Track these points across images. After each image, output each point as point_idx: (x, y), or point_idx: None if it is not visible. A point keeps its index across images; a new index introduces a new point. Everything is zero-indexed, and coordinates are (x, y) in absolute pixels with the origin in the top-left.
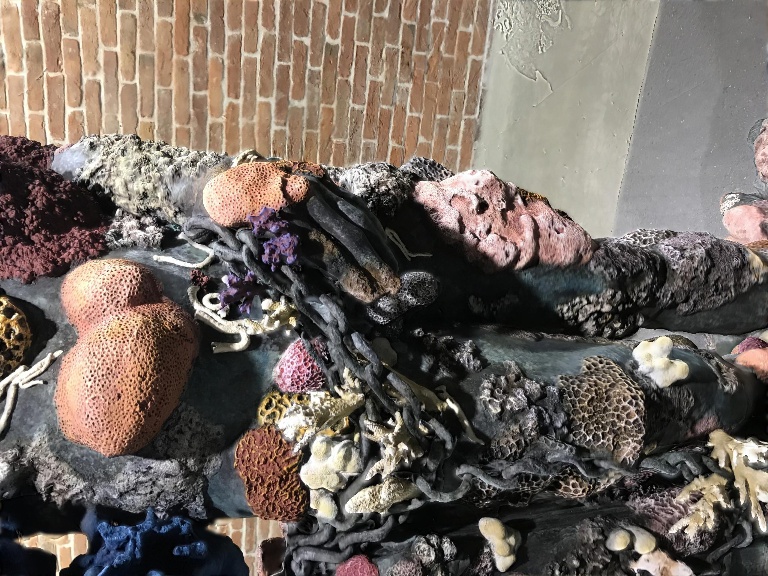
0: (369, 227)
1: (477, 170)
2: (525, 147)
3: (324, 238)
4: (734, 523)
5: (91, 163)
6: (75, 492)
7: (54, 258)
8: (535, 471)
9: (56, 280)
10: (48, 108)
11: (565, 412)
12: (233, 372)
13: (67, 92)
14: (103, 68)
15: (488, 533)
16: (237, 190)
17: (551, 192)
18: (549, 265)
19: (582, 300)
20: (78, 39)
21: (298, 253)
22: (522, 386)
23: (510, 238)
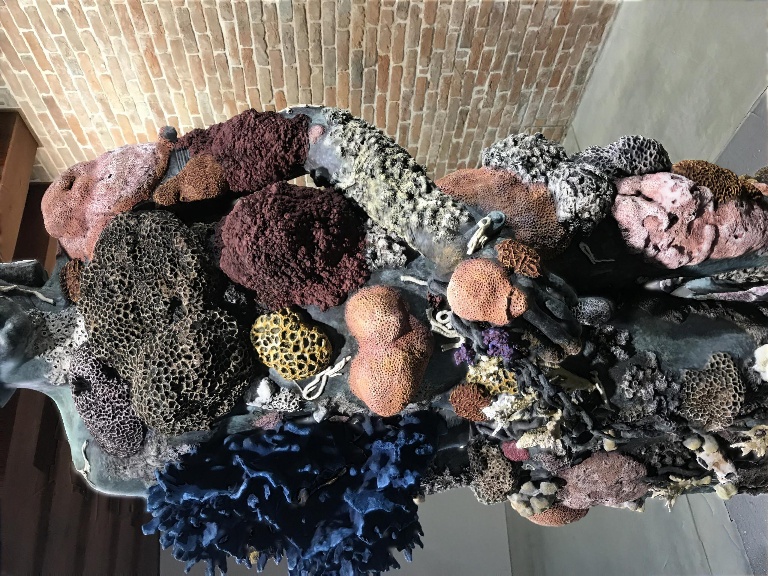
0: (566, 317)
1: (679, 182)
2: None
3: (532, 337)
4: None
5: (346, 178)
6: (359, 411)
7: (338, 291)
8: None
9: (341, 307)
10: None
11: (680, 400)
12: (453, 358)
13: None
14: None
15: None
16: (474, 307)
17: None
18: (717, 259)
19: (739, 272)
20: None
21: (512, 354)
22: (654, 381)
23: (688, 247)
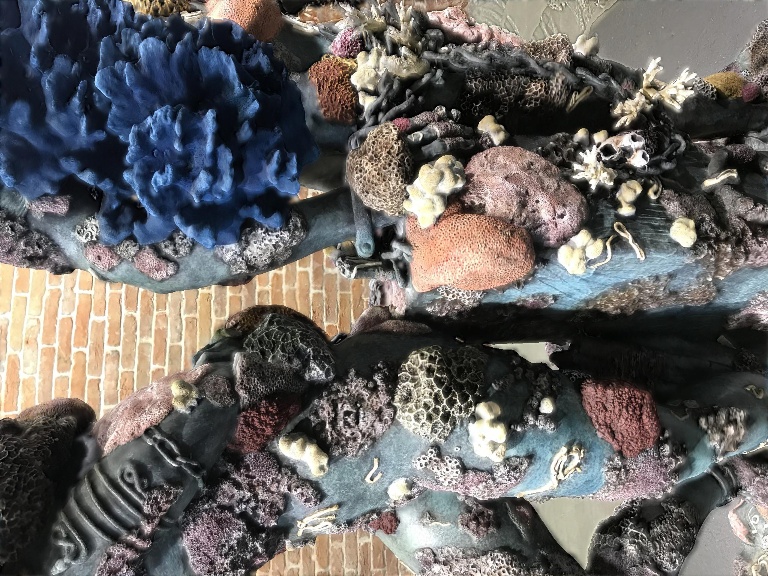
0: None
1: None
2: None
3: None
4: (668, 136)
5: None
6: None
7: None
8: (501, 54)
9: None
10: (125, 287)
11: None
12: (305, 39)
13: None
14: None
15: (484, 124)
16: None
17: None
18: None
19: None
20: None
21: None
22: None
23: None
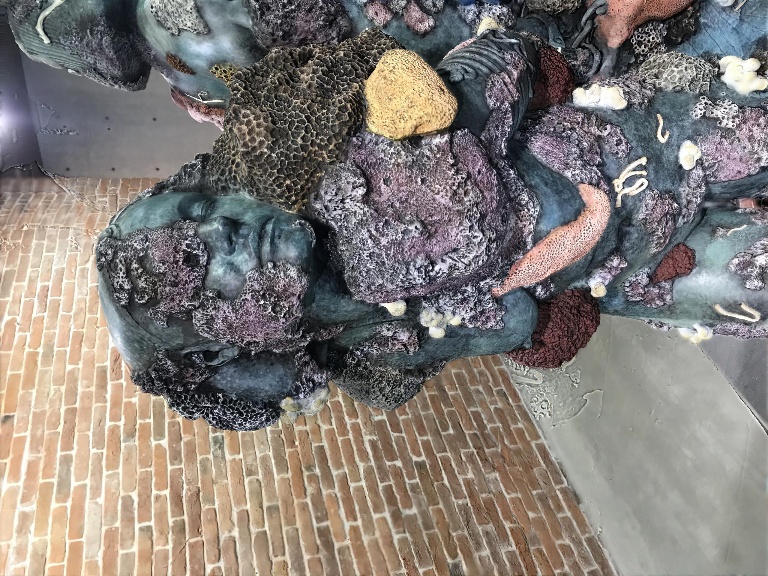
0: None
1: None
2: (616, 449)
3: None
4: None
5: None
6: None
7: None
8: None
9: None
10: (190, 573)
11: None
12: None
13: (206, 555)
14: (237, 526)
15: None
16: None
17: (659, 443)
18: None
19: None
20: (215, 507)
21: None
22: None
23: None
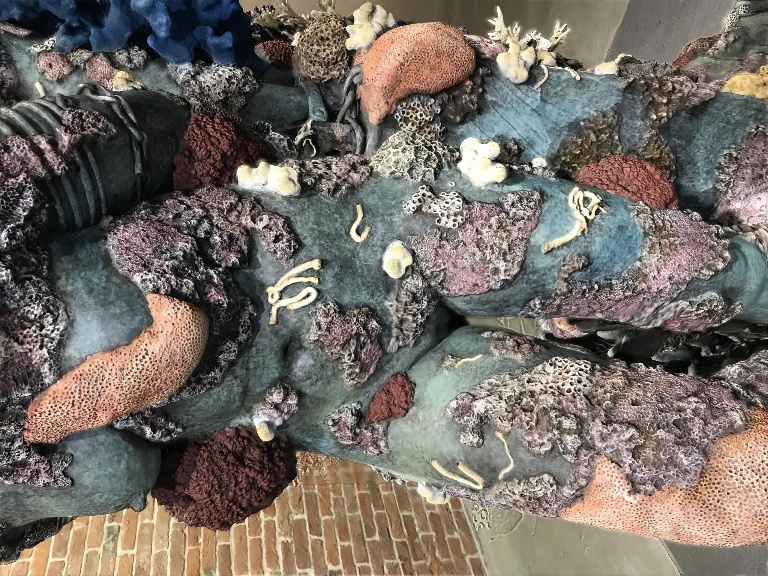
0: None
1: None
2: (548, 575)
3: None
4: None
5: None
6: None
7: None
8: None
9: None
10: None
11: None
12: None
13: None
14: None
15: None
16: None
17: (588, 575)
18: None
19: None
20: None
21: None
22: None
23: None
